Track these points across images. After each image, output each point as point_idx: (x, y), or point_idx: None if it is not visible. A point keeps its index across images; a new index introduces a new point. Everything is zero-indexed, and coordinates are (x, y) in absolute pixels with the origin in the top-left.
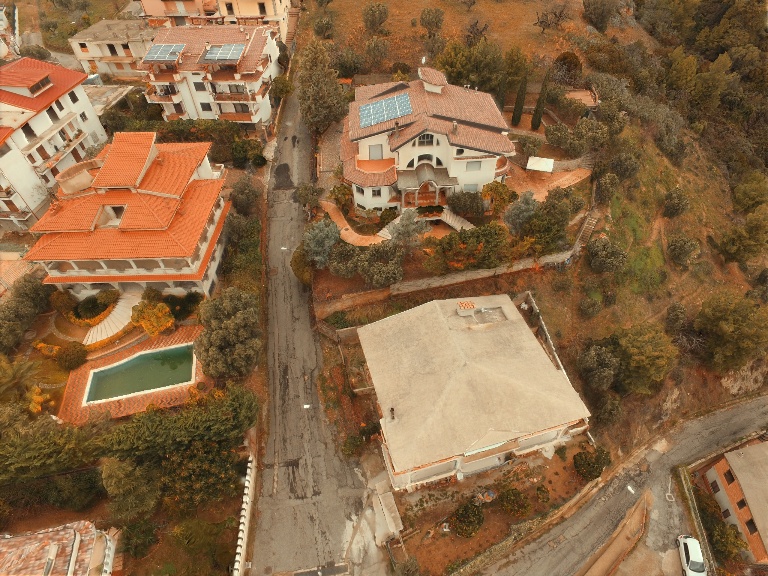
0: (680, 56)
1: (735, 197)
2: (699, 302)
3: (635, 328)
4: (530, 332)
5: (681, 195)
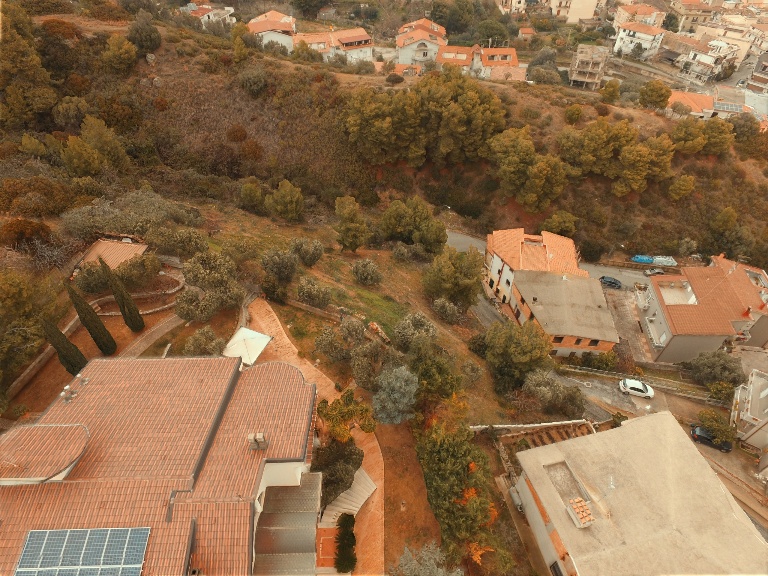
0: (35, 144)
1: (276, 211)
2: (408, 288)
3: (502, 343)
4: (576, 440)
5: (300, 242)
